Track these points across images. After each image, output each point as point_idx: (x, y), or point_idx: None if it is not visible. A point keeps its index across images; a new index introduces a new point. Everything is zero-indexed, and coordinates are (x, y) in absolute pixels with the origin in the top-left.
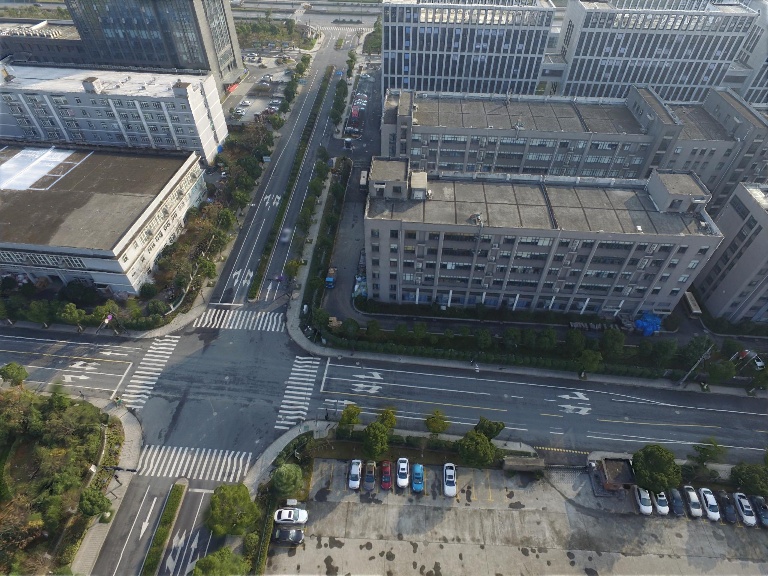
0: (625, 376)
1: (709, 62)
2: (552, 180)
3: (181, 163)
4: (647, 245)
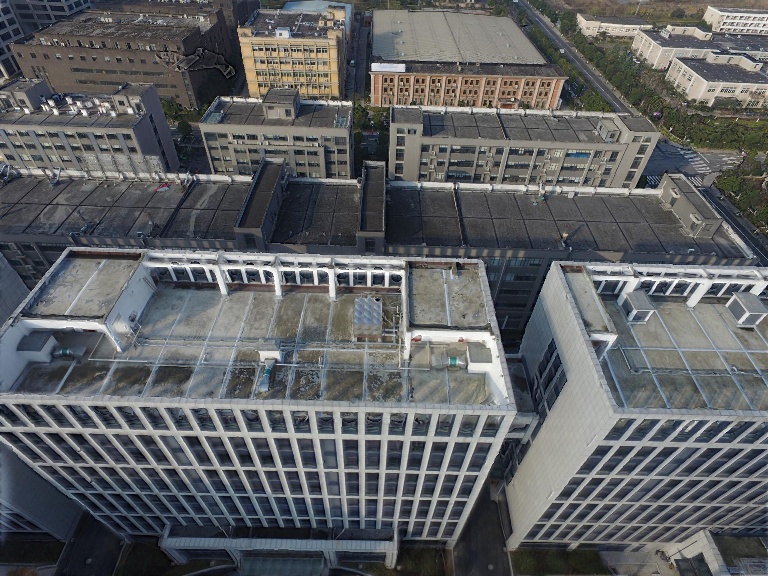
0: None
1: None
2: (500, 143)
3: None
4: None
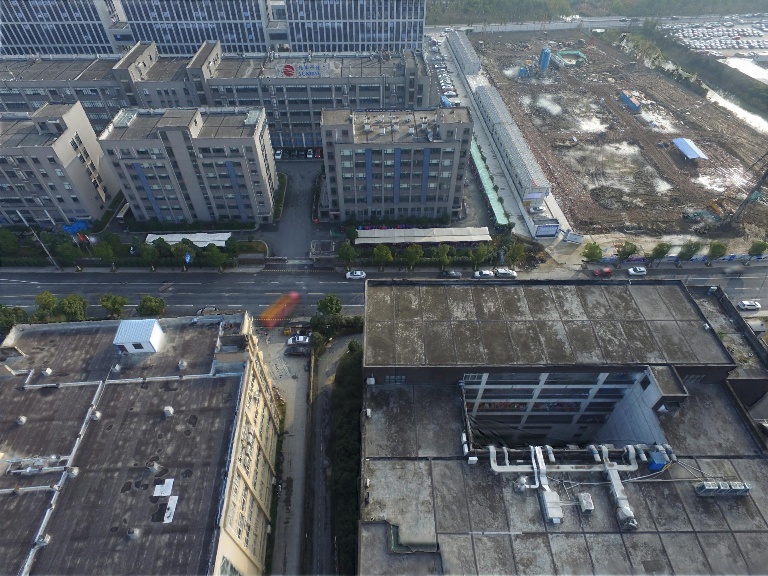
0: (20, 266)
1: (244, 22)
2: None
3: None
4: (5, 158)
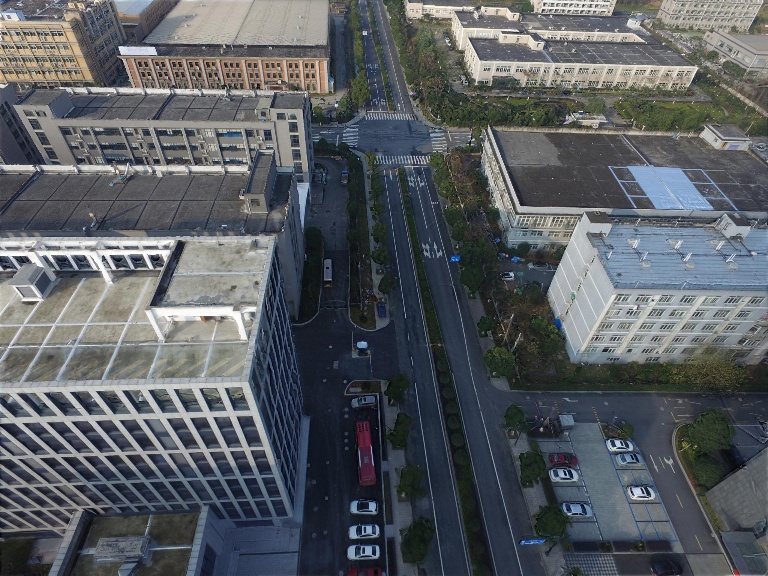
0: None
1: None
2: (141, 124)
3: (525, 201)
4: None
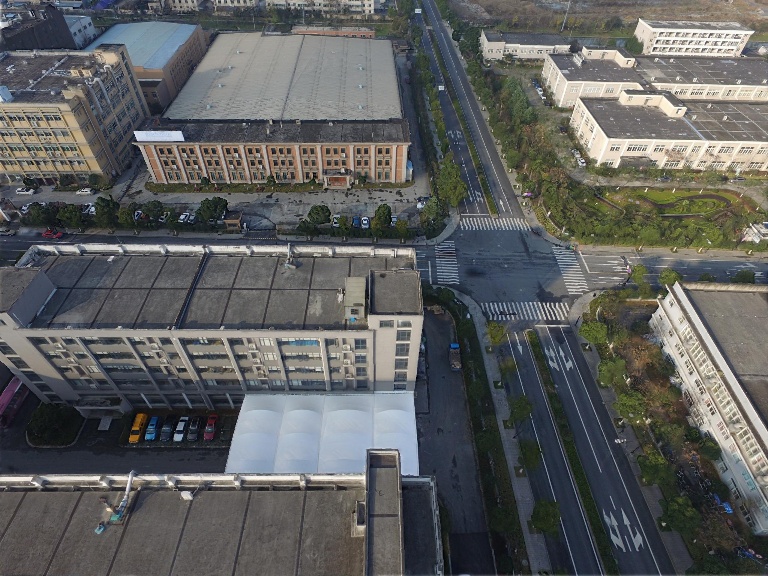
0: None
1: None
2: (158, 333)
3: None
4: None
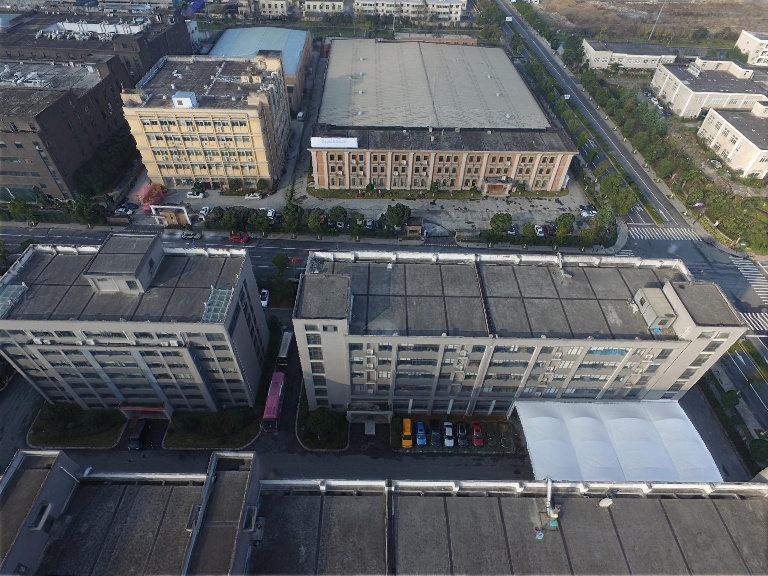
0: None
1: None
2: (479, 341)
3: None
4: None
